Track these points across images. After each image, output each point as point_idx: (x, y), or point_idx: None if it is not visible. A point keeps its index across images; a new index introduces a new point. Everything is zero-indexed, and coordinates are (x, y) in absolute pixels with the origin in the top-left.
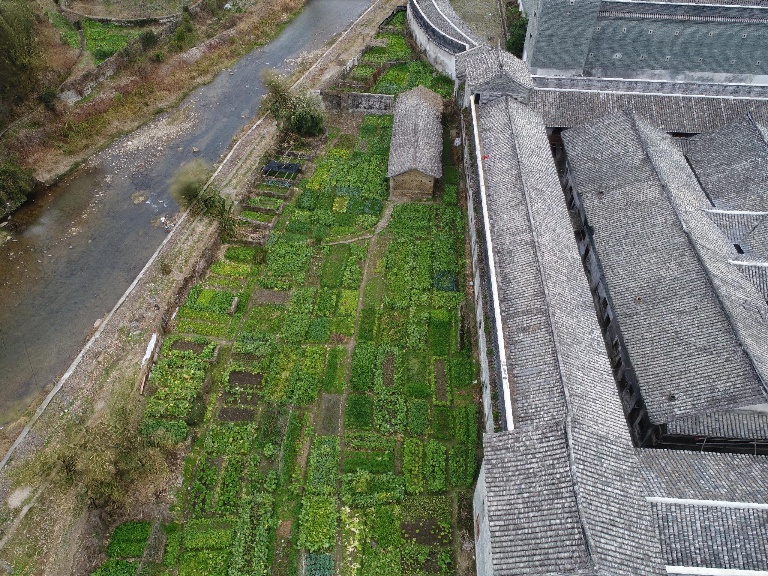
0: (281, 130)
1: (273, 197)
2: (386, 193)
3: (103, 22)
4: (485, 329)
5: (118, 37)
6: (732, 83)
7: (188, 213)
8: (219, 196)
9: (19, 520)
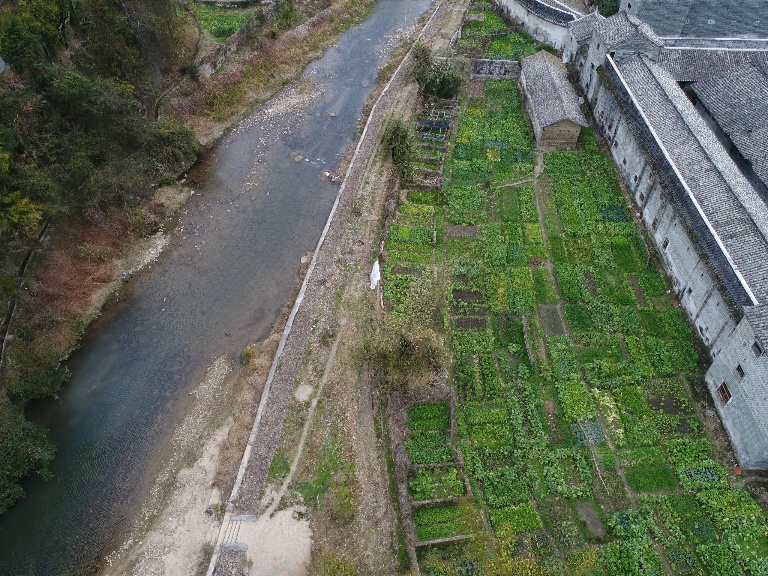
0: (420, 93)
1: (432, 150)
2: (532, 144)
3: (207, 4)
4: (693, 238)
5: (227, 17)
6: None
7: (353, 167)
8: (406, 143)
9: (313, 409)
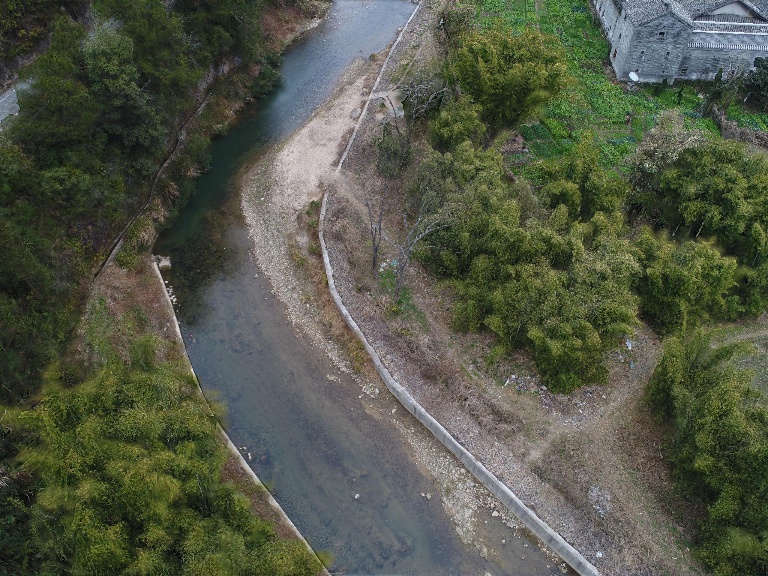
0: None
1: None
2: None
3: None
4: None
5: None
6: None
7: None
8: None
9: None
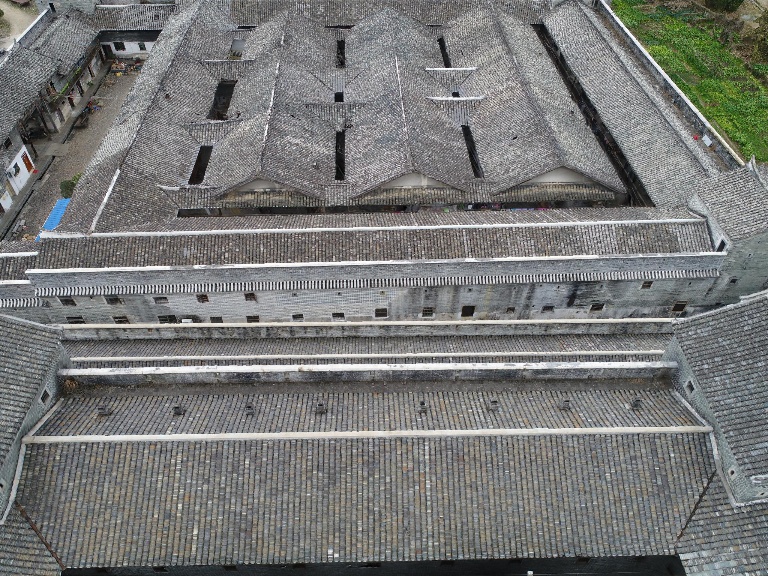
0: None
1: None
2: None
3: None
4: None
5: None
6: (386, 261)
7: None
8: None
9: None
